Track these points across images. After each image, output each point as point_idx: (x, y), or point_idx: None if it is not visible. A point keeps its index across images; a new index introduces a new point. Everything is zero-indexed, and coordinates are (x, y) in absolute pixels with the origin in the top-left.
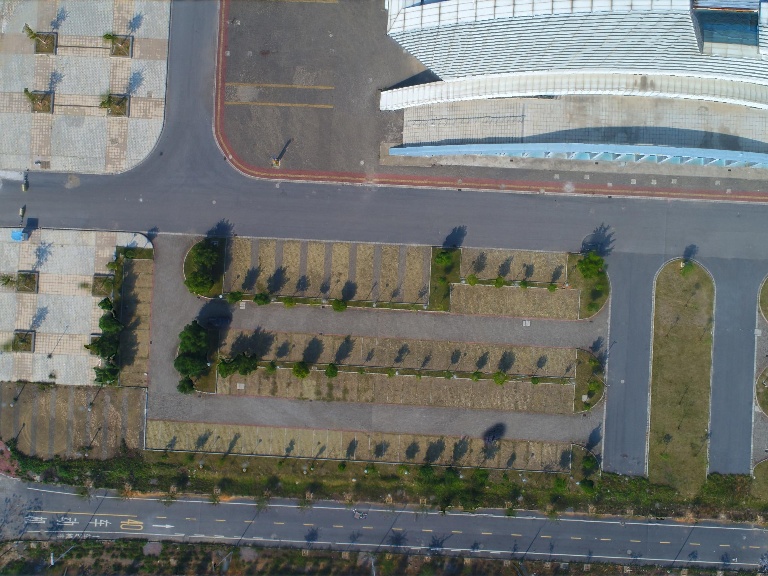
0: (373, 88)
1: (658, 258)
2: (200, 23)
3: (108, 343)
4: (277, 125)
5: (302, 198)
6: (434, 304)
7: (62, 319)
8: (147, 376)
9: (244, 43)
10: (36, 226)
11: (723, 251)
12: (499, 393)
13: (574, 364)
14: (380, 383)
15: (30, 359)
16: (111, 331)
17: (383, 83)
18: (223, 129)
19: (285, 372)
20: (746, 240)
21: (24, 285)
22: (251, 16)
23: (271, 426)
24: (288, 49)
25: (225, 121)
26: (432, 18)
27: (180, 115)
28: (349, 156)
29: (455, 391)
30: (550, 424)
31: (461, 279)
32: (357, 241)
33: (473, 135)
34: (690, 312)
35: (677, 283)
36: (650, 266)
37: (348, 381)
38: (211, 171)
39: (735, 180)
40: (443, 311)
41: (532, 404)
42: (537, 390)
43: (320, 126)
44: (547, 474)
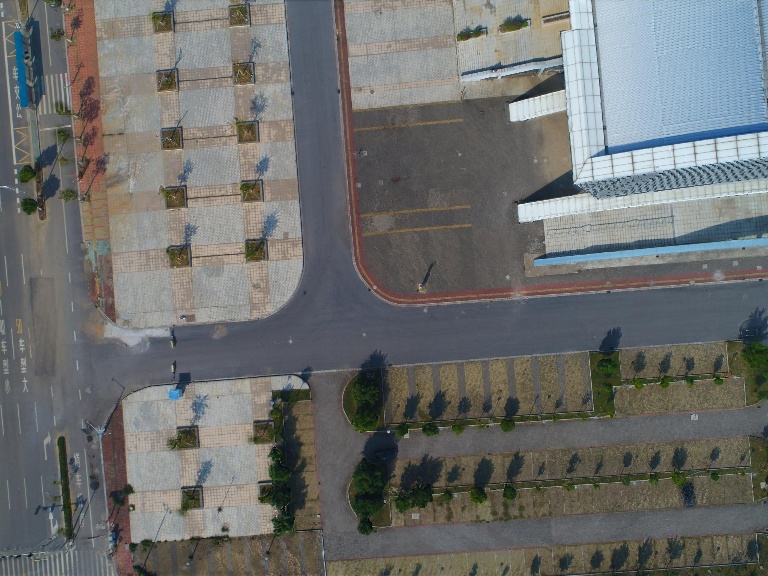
0: (509, 201)
1: None
2: (327, 158)
3: (282, 493)
4: (418, 250)
5: (452, 320)
6: (599, 410)
7: (227, 471)
8: (320, 518)
9: (374, 173)
10: (189, 380)
11: None
12: (676, 491)
13: (748, 452)
14: (555, 496)
15: (200, 515)
16: (283, 480)
17: (518, 195)
18: (364, 261)
19: (458, 496)
20: None
21: (186, 442)
22: (377, 145)
23: (451, 553)
24: (419, 173)
25: (365, 253)
26: (625, 167)
27: (319, 252)
28: (494, 272)
29: (632, 494)
30: (732, 515)
31: (623, 381)
32: (513, 356)
33: (621, 240)
34: None
35: None
36: None
37: (523, 498)
38: (357, 304)
39: None
40: (609, 415)
41: (711, 498)
42: (714, 483)
43: (461, 246)
44: (736, 567)
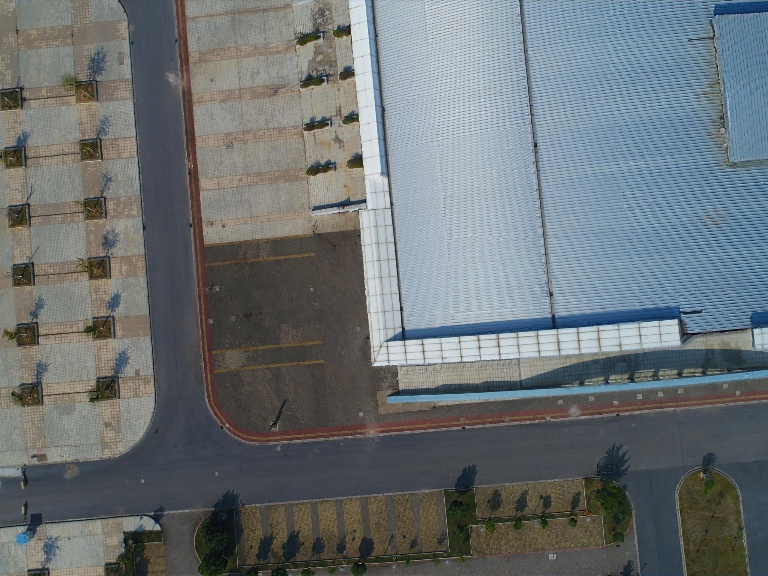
0: (361, 337)
1: (676, 471)
2: (179, 293)
3: None
4: (270, 387)
5: (305, 458)
6: (455, 550)
7: None
8: None
9: (226, 308)
10: (40, 521)
11: (742, 455)
12: None
13: None
14: None
15: None
16: None
17: None
18: (216, 398)
19: None
20: (764, 440)
21: None
22: (229, 280)
23: None
24: (271, 309)
25: (217, 390)
26: (416, 355)
27: (171, 389)
28: (347, 409)
29: None
30: None
31: (478, 520)
32: (367, 495)
33: (470, 380)
34: (718, 523)
35: (700, 494)
36: (670, 480)
37: None
38: (209, 442)
39: (743, 381)
40: (465, 556)
41: None
42: None
43: (313, 383)
44: None
